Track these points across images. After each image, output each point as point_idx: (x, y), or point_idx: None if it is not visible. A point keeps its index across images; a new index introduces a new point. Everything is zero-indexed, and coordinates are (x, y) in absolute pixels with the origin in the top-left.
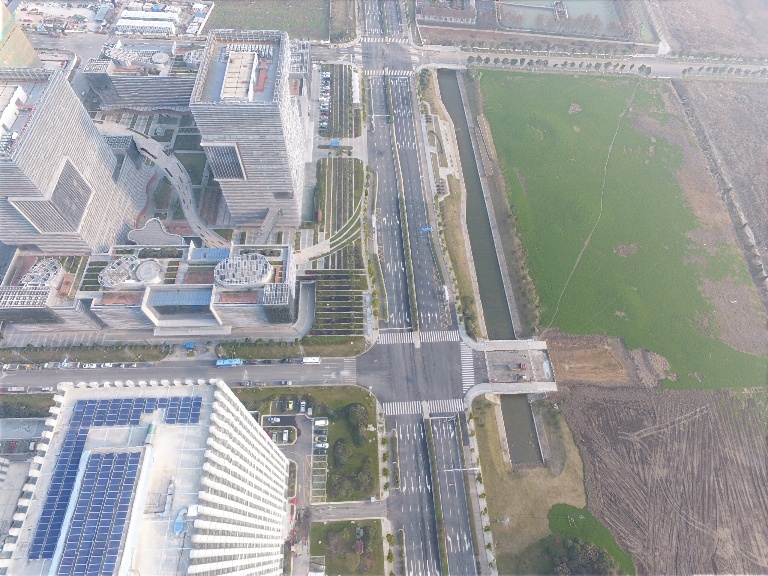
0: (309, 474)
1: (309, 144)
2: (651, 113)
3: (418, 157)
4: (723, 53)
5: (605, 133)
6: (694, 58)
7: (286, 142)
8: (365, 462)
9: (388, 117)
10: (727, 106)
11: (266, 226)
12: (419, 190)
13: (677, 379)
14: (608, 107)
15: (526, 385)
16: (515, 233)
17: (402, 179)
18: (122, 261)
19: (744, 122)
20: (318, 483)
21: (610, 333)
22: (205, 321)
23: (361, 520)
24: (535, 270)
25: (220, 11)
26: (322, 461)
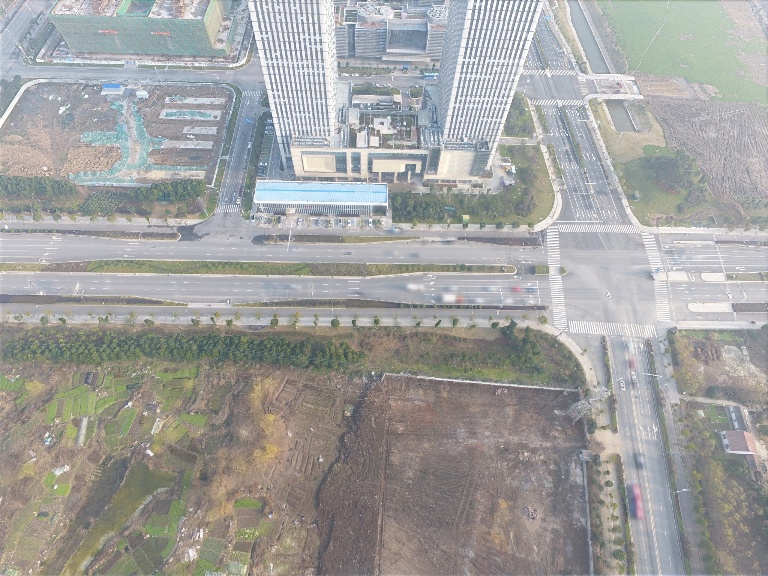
0: None
1: None
2: None
3: None
4: None
5: None
6: None
7: None
8: None
9: None
10: None
11: (447, 3)
12: None
13: (723, 97)
14: None
15: (623, 95)
16: (607, 26)
17: None
18: (369, 6)
19: None
20: None
21: (677, 75)
22: (416, 50)
23: (528, 145)
24: None
25: None
26: None
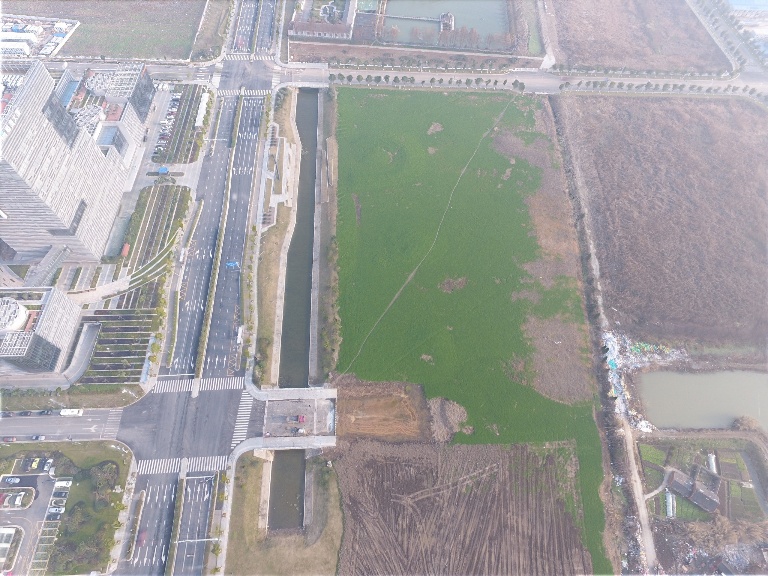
0: (34, 543)
1: (133, 171)
2: (518, 132)
3: (252, 183)
4: (612, 66)
5: (461, 155)
6: (577, 72)
7: (32, 179)
8: (99, 529)
9: (231, 140)
10: (602, 123)
11: (43, 265)
12: (243, 220)
13: (472, 432)
14: (472, 126)
15: (302, 440)
16: (334, 267)
17: (228, 208)
18: None
19: (615, 141)
20: (41, 554)
21: (410, 379)
22: None
23: None
24: (346, 308)
25: (84, 30)
26: (53, 528)
